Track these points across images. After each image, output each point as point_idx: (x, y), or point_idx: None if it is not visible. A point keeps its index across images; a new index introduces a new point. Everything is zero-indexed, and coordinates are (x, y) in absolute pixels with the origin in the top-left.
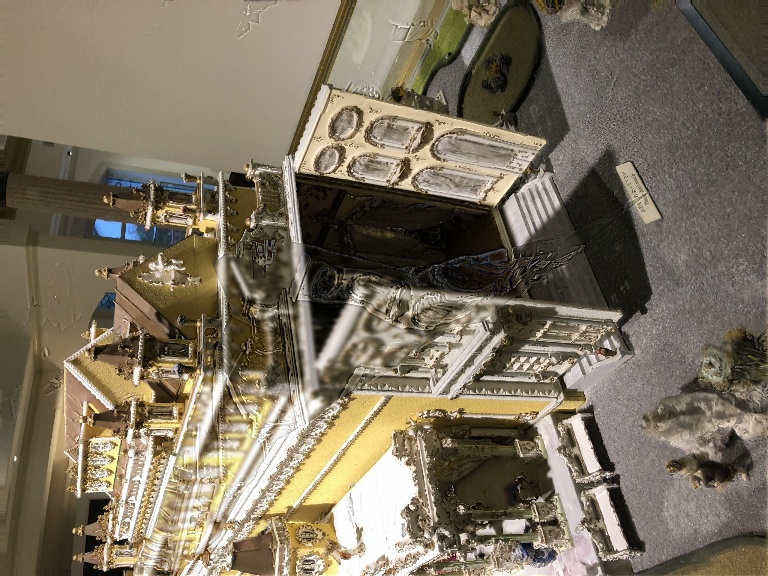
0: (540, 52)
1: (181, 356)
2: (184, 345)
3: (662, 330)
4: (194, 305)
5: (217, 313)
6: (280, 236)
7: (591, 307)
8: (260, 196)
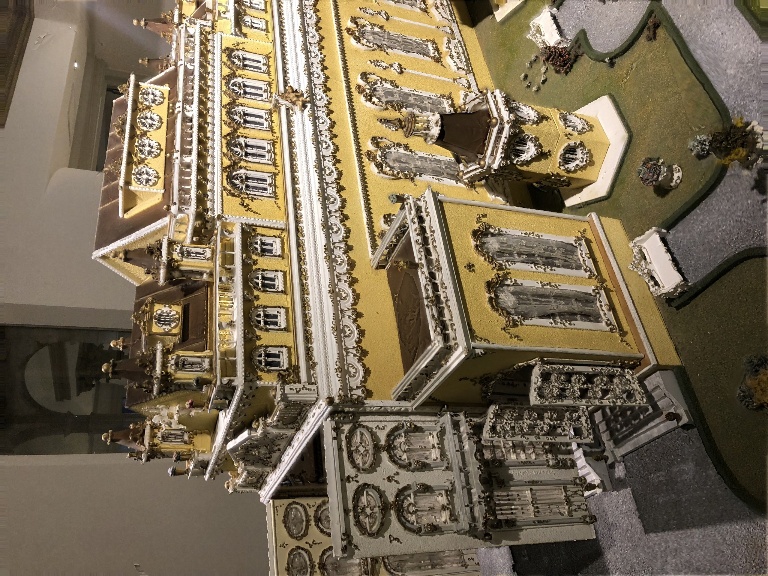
0: (764, 507)
1: None
2: None
3: None
4: None
5: (211, 437)
6: None
7: None
8: (276, 417)
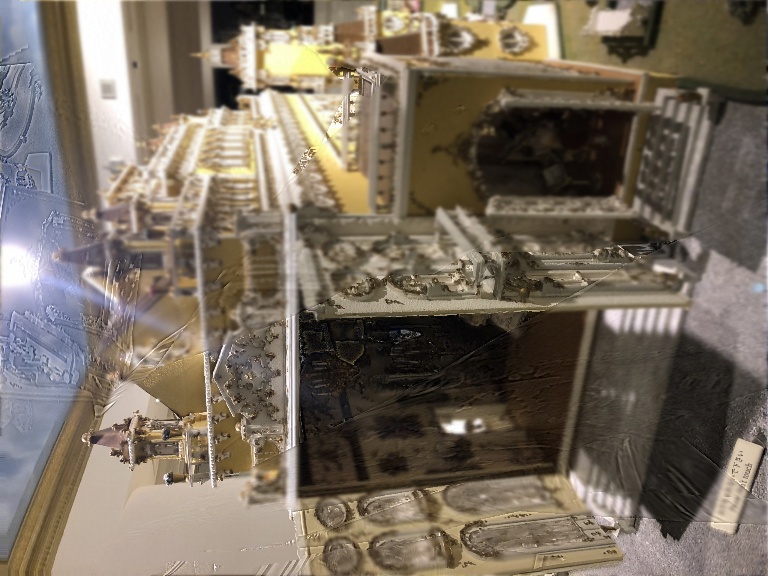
0: None
1: (172, 453)
2: (174, 442)
3: (662, 568)
4: (183, 379)
5: None
6: (273, 337)
7: (584, 563)
8: None
